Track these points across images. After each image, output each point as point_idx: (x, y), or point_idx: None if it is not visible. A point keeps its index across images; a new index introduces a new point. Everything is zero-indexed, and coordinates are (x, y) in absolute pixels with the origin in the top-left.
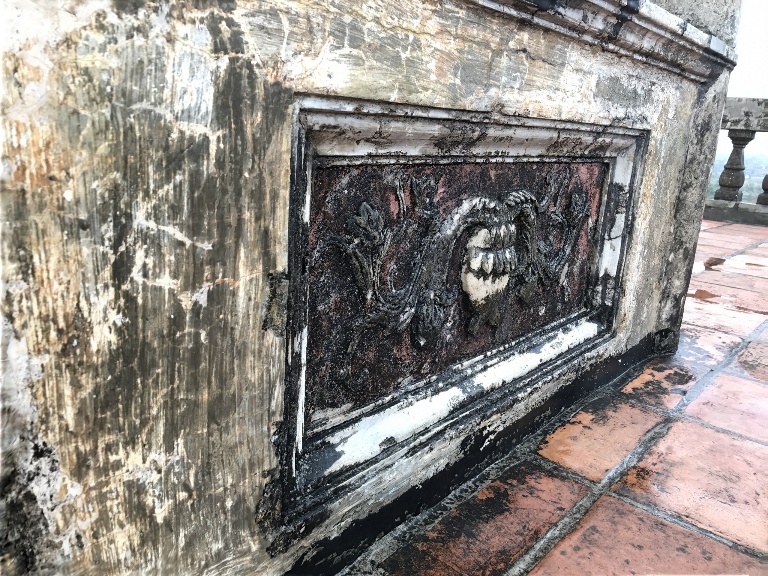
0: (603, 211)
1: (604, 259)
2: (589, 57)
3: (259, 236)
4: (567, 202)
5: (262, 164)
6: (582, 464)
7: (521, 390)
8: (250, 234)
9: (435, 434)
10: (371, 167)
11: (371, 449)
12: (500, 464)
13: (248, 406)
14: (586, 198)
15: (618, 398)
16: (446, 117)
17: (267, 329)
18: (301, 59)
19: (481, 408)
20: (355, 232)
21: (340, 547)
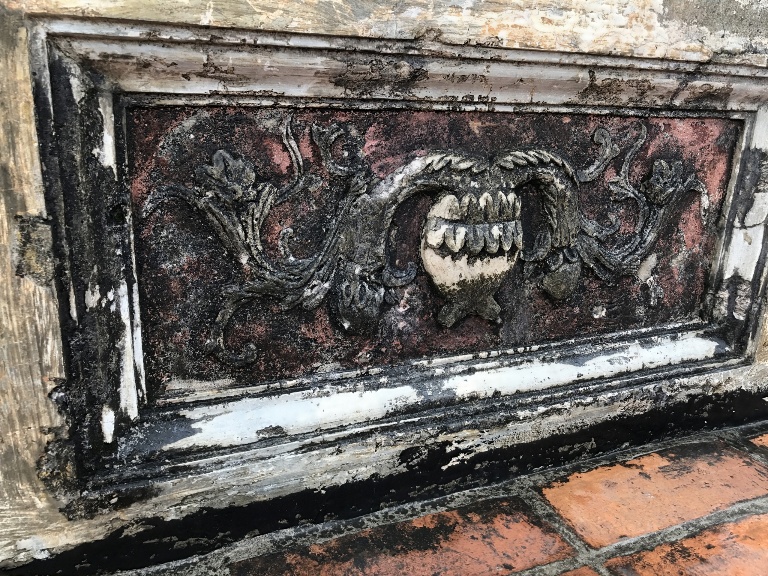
0: (732, 188)
1: (733, 255)
2: None
3: None
4: (646, 171)
5: None
6: (592, 519)
7: (527, 407)
8: None
9: (352, 435)
10: (234, 109)
11: (242, 434)
12: (477, 492)
13: (8, 355)
14: (692, 168)
15: (734, 448)
16: (326, 46)
17: (24, 276)
18: None
19: (444, 418)
20: (206, 184)
21: (182, 532)
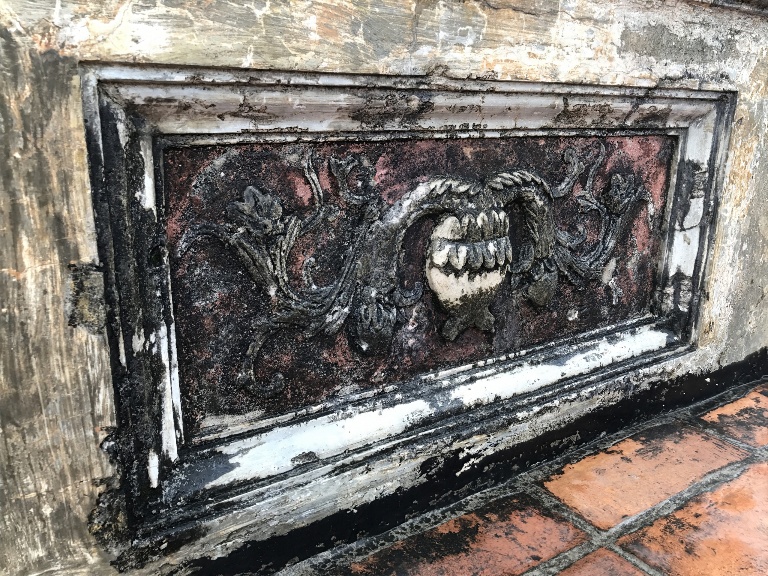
0: (672, 195)
1: (675, 254)
2: (603, 2)
3: (48, 223)
4: (605, 184)
5: (40, 143)
6: (594, 505)
7: (524, 408)
8: (34, 221)
9: (378, 452)
10: (260, 146)
11: (278, 464)
12: (488, 493)
13: (60, 408)
14: (640, 179)
15: (690, 426)
16: (350, 84)
17: (77, 325)
18: (86, 23)
19: (455, 426)
20: (238, 220)
21: (228, 569)
